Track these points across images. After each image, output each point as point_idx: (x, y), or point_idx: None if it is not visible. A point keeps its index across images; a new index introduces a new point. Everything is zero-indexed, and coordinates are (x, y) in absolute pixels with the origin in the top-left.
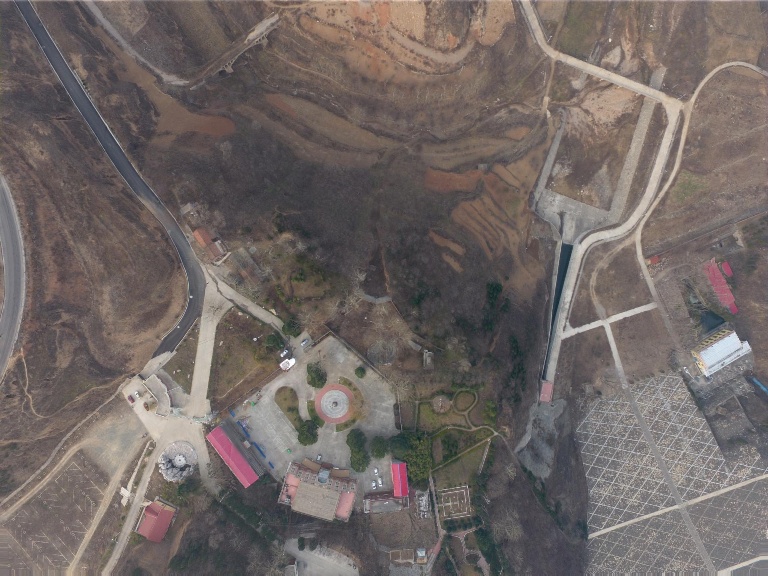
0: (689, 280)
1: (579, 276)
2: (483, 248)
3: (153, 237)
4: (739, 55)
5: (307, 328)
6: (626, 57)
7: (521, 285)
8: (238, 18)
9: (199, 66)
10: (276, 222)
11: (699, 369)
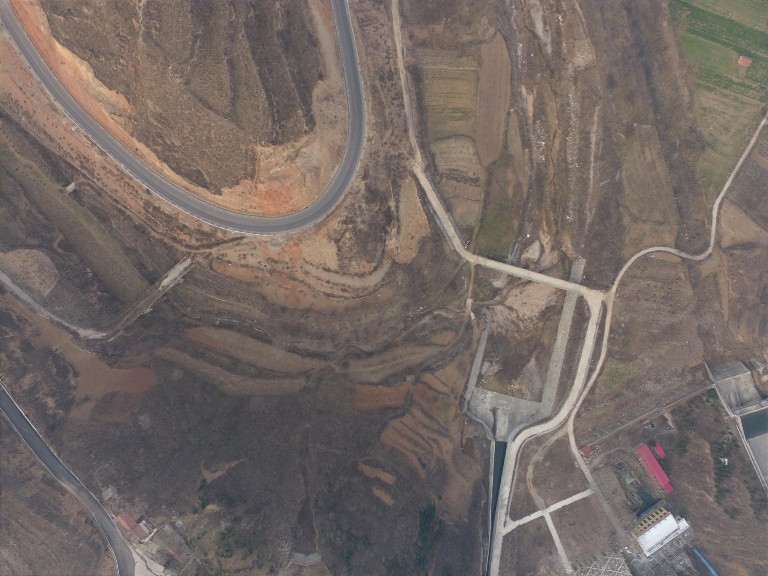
0: (624, 463)
1: (515, 472)
2: (415, 467)
3: (76, 530)
4: (656, 241)
5: None
6: (545, 250)
7: (456, 496)
8: (152, 257)
9: (116, 314)
10: (199, 496)
11: (640, 547)
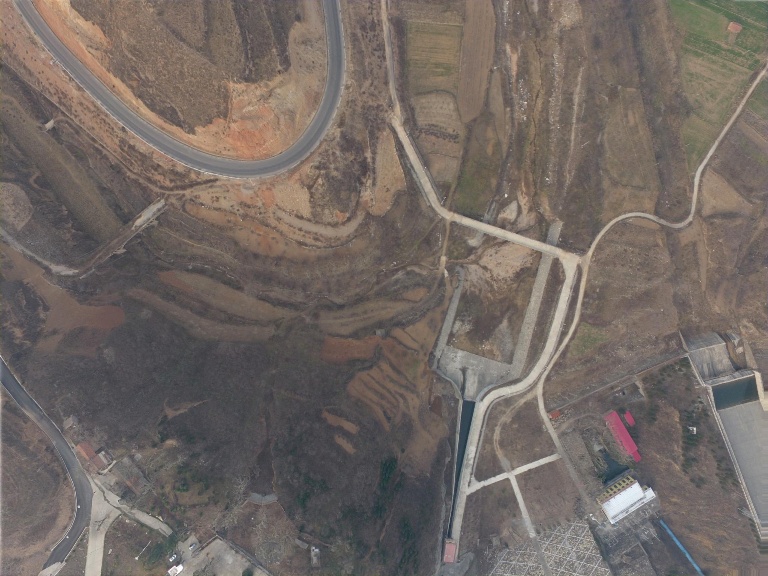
0: (592, 430)
1: (482, 432)
2: (380, 420)
3: (35, 456)
4: (635, 206)
5: (194, 532)
6: (523, 211)
7: (420, 451)
8: (128, 198)
9: (89, 252)
10: (159, 430)
11: (605, 515)
